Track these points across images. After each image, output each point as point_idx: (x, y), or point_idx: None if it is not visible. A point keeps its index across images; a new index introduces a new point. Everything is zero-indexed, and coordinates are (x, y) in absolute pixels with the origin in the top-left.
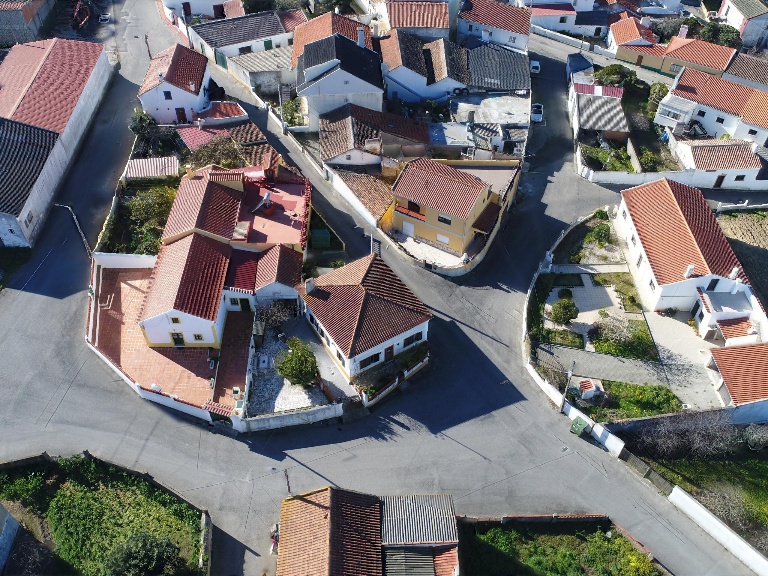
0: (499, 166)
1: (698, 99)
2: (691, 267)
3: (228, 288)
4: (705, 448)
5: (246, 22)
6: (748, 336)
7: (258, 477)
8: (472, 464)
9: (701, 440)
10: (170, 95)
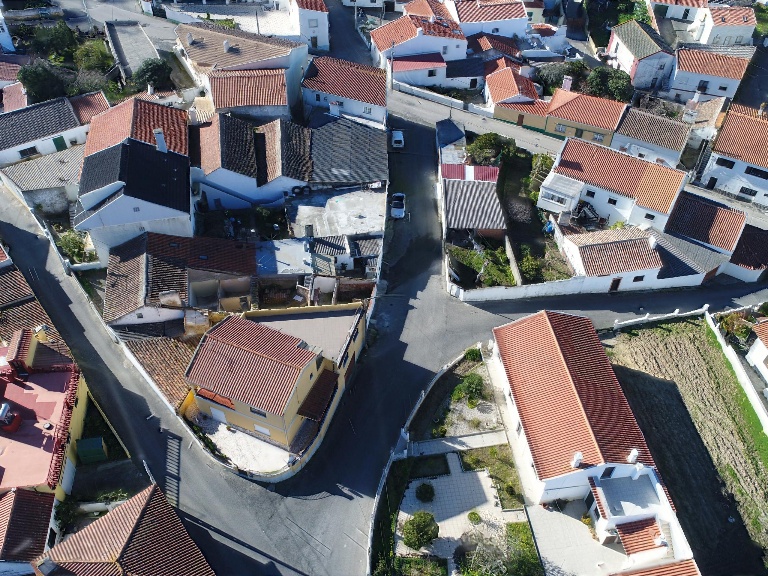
0: (337, 311)
1: (585, 178)
2: (578, 458)
3: None
4: None
5: (27, 116)
6: (656, 550)
7: None
8: None
9: None
10: None
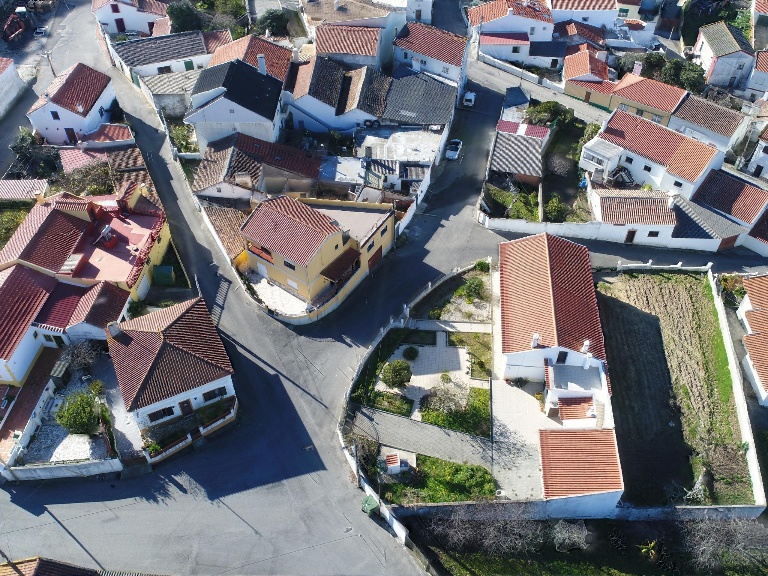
0: (372, 209)
1: (625, 144)
2: (535, 337)
3: (37, 324)
4: (499, 544)
5: (168, 41)
6: (585, 419)
7: (7, 532)
8: (240, 538)
9: (496, 535)
10: (58, 115)
